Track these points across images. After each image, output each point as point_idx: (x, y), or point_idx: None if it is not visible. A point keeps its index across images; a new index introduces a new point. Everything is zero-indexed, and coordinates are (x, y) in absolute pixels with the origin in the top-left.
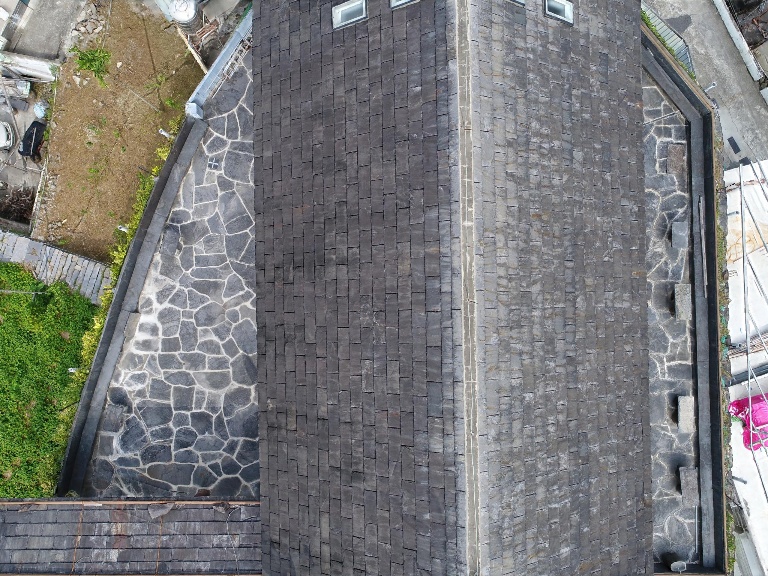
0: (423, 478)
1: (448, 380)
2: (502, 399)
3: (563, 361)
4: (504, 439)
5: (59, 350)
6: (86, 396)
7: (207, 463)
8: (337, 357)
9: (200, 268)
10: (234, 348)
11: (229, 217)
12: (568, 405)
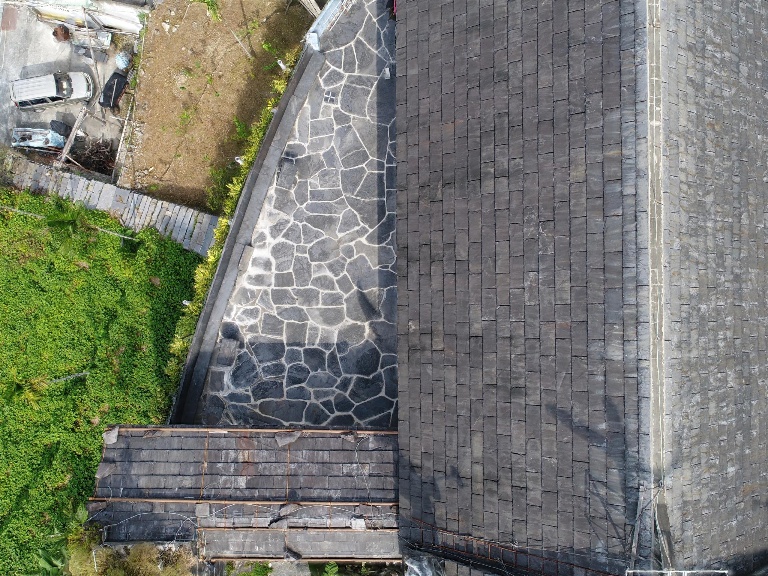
0: (598, 387)
1: (630, 284)
2: (682, 307)
3: (731, 277)
4: (684, 348)
5: (150, 296)
6: (200, 329)
7: (319, 400)
8: (494, 272)
9: (315, 202)
10: (348, 284)
11: (345, 151)
12: (734, 322)
